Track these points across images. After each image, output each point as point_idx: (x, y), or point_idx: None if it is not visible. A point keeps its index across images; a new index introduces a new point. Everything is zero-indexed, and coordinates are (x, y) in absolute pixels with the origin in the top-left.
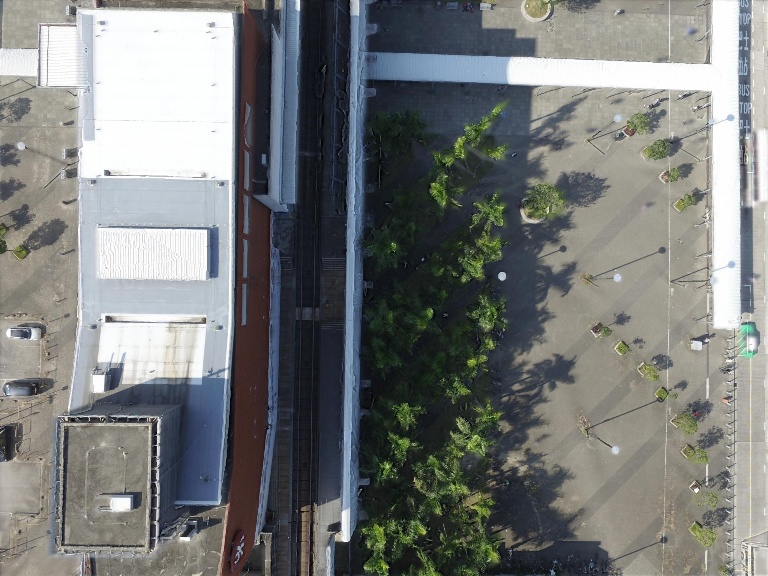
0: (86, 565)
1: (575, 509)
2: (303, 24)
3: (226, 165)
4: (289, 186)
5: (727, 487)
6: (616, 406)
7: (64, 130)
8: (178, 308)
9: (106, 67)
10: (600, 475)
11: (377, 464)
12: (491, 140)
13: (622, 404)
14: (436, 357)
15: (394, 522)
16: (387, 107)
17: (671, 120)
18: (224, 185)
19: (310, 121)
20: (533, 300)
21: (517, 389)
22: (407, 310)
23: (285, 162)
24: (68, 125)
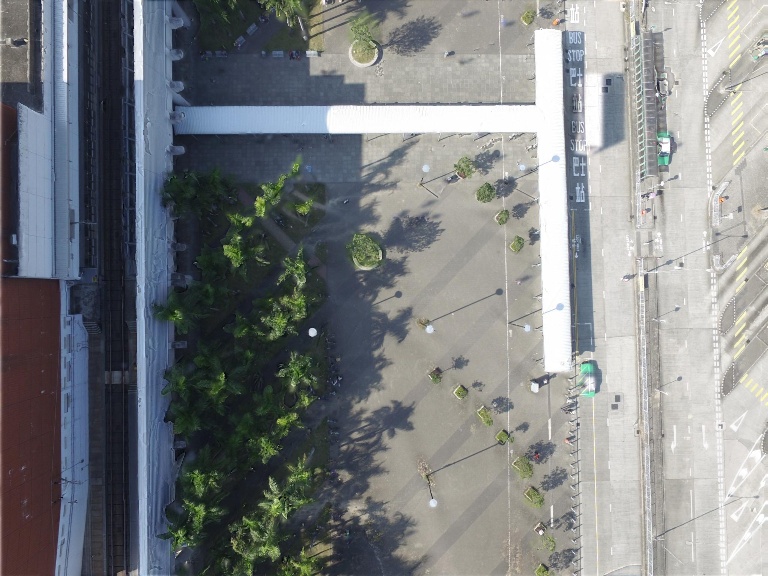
0: None
1: (418, 556)
2: (105, 85)
3: None
4: (61, 259)
5: (573, 528)
6: (457, 451)
7: None
8: None
9: None
10: (443, 521)
11: (172, 533)
12: (322, 188)
13: (463, 448)
14: (243, 418)
15: None
16: (216, 158)
17: (505, 160)
18: None
19: (115, 182)
20: (369, 347)
21: (356, 437)
22: (211, 372)
23: (56, 235)
24: None
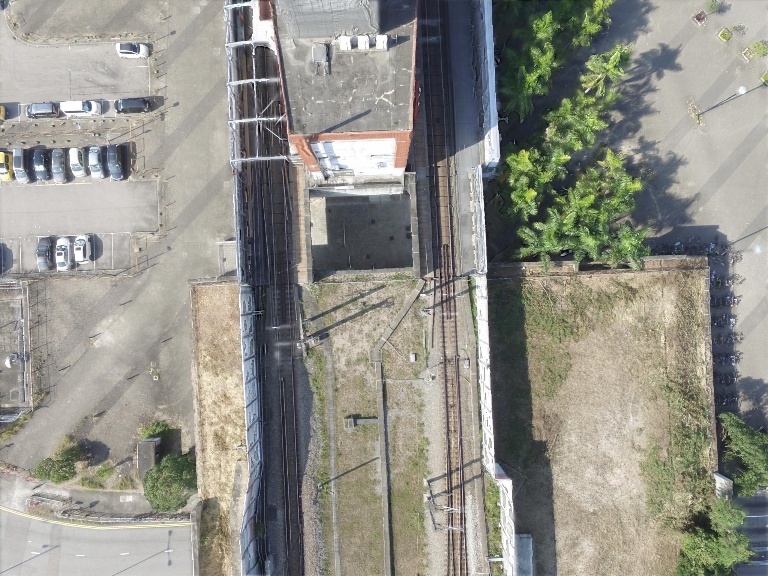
0: (238, 197)
1: (692, 194)
2: None
3: None
4: None
5: None
6: (724, 92)
7: None
8: None
9: None
10: (714, 160)
11: (523, 78)
12: None
13: (730, 89)
14: None
15: (537, 152)
16: None
17: None
18: None
19: None
20: None
21: (626, 79)
22: None
23: None
24: None
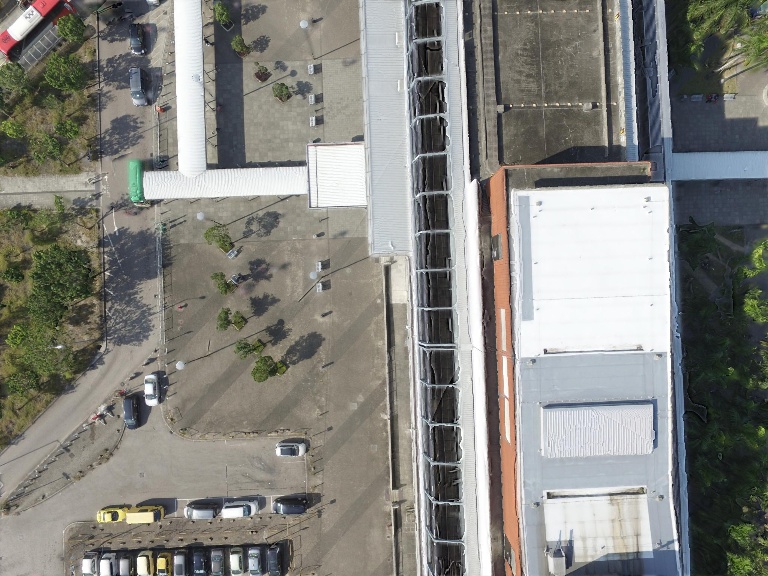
0: None
1: None
2: None
3: (664, 337)
4: None
5: None
6: None
7: (315, 242)
8: (618, 480)
9: (544, 247)
10: None
11: None
12: (741, 230)
13: None
14: (748, 467)
15: None
16: None
17: None
18: (662, 357)
19: None
20: None
21: None
22: None
23: None
24: (319, 237)
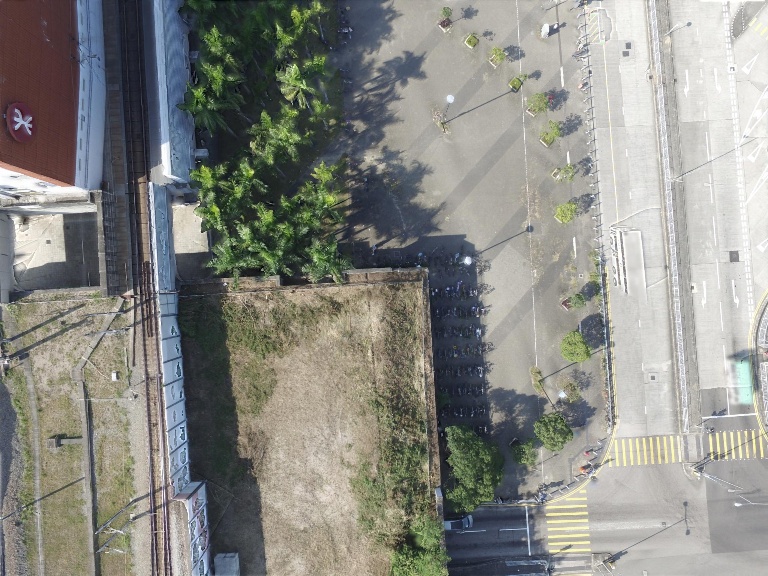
0: None
1: (437, 203)
2: None
3: None
4: None
5: (590, 173)
6: (471, 99)
7: None
8: None
9: None
10: (460, 168)
11: (192, 94)
12: None
13: (476, 97)
14: (257, 9)
15: (222, 167)
16: None
17: None
18: None
19: None
20: None
21: (369, 88)
22: None
23: None
24: None
